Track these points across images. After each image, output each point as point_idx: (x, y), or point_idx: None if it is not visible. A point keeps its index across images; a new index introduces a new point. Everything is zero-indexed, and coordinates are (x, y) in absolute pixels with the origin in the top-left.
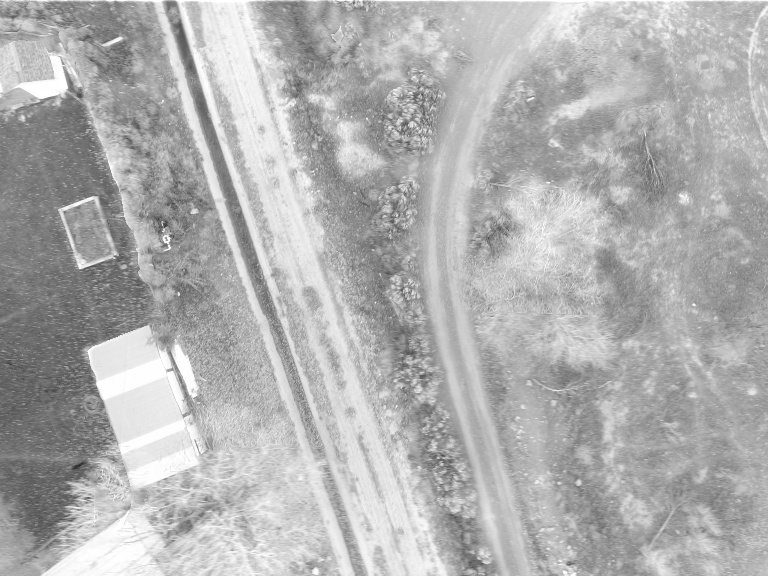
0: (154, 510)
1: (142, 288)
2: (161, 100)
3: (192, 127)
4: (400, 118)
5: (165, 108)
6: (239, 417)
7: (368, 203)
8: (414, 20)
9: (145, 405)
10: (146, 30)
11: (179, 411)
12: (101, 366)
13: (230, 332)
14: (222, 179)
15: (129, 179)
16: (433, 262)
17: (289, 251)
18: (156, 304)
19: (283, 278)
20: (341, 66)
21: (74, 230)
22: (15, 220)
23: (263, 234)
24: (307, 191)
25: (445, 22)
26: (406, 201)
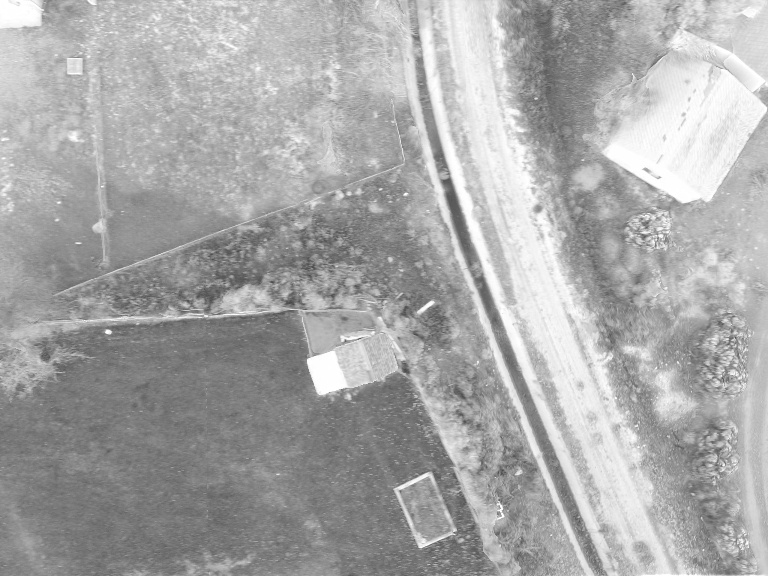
0: None
1: (482, 561)
2: (476, 361)
3: (507, 385)
4: (720, 367)
5: (482, 370)
6: None
7: (682, 445)
8: (707, 252)
9: None
10: (456, 291)
11: None
12: None
13: None
14: (536, 432)
15: (469, 458)
16: (752, 501)
17: (616, 506)
18: None
19: (612, 534)
20: (646, 309)
21: (413, 510)
22: (351, 503)
23: (589, 491)
24: (633, 447)
25: (738, 252)
26: (731, 449)
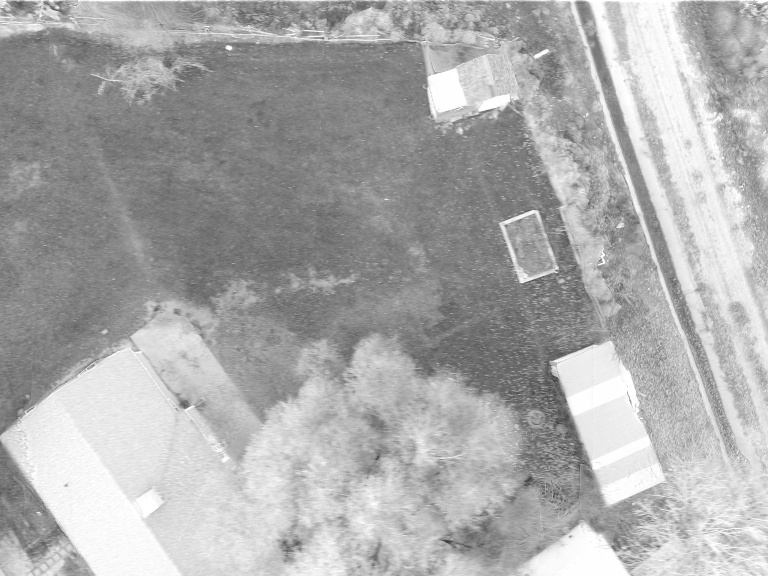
0: (739, 531)
1: (581, 302)
2: (585, 113)
3: (614, 141)
4: None
5: (591, 121)
6: (673, 432)
7: None
8: None
9: (613, 421)
10: (570, 43)
11: (643, 427)
12: (571, 382)
13: (659, 347)
14: (638, 193)
15: (578, 193)
16: None
17: (715, 266)
18: (596, 319)
19: (709, 293)
20: (756, 80)
21: (518, 244)
22: (456, 233)
23: (689, 249)
24: (737, 206)
25: None
26: None
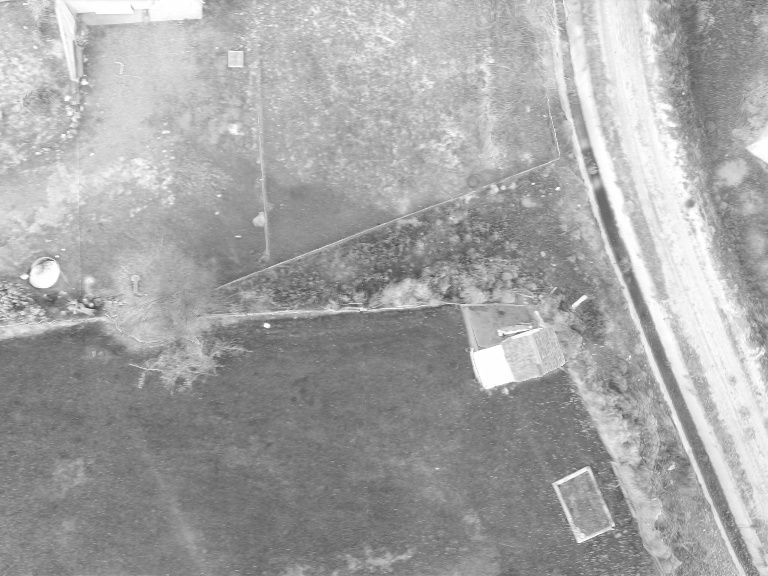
0: None
1: (639, 556)
2: (628, 356)
3: (658, 380)
4: None
5: (635, 365)
6: None
7: None
8: None
9: None
10: (608, 286)
11: None
12: None
13: None
14: (685, 427)
15: (630, 452)
16: None
17: None
18: (656, 572)
19: (764, 529)
20: None
21: (573, 505)
22: (509, 497)
23: (741, 486)
24: None
25: None
26: None
